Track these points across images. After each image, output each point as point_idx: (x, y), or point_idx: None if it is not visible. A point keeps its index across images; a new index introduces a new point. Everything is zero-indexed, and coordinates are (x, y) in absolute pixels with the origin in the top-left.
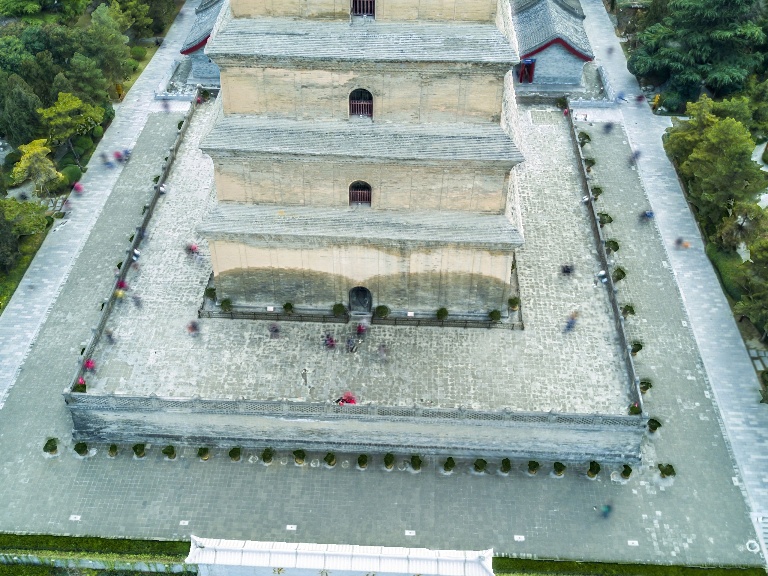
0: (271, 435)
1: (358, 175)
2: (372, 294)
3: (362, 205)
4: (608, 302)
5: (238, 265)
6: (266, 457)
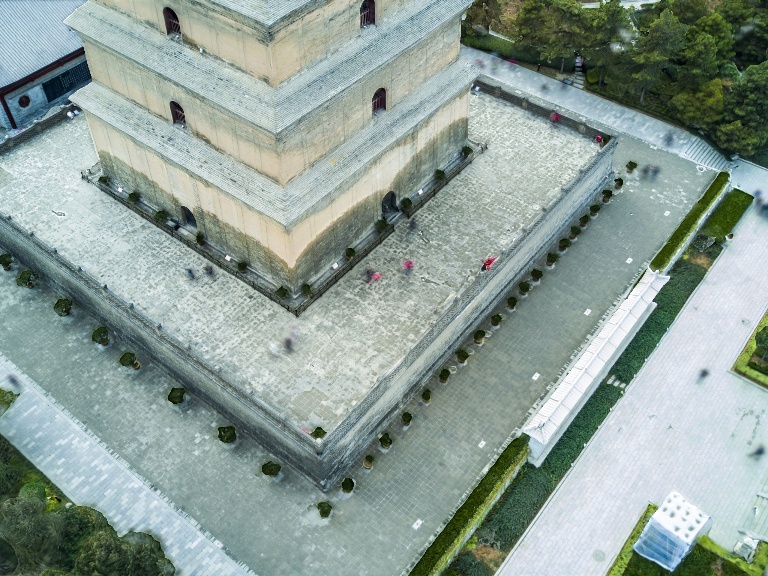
0: (450, 341)
1: (377, 84)
2: (395, 194)
3: (378, 114)
4: (497, 99)
5: (309, 240)
6: (466, 356)
